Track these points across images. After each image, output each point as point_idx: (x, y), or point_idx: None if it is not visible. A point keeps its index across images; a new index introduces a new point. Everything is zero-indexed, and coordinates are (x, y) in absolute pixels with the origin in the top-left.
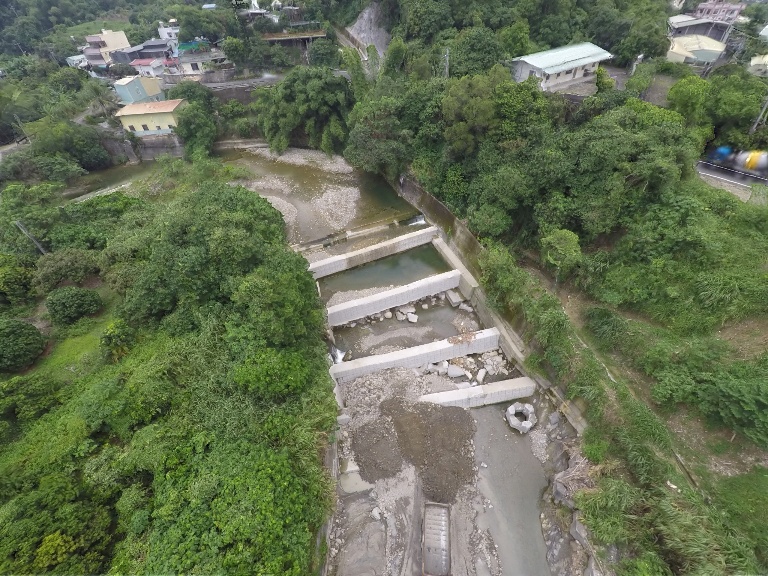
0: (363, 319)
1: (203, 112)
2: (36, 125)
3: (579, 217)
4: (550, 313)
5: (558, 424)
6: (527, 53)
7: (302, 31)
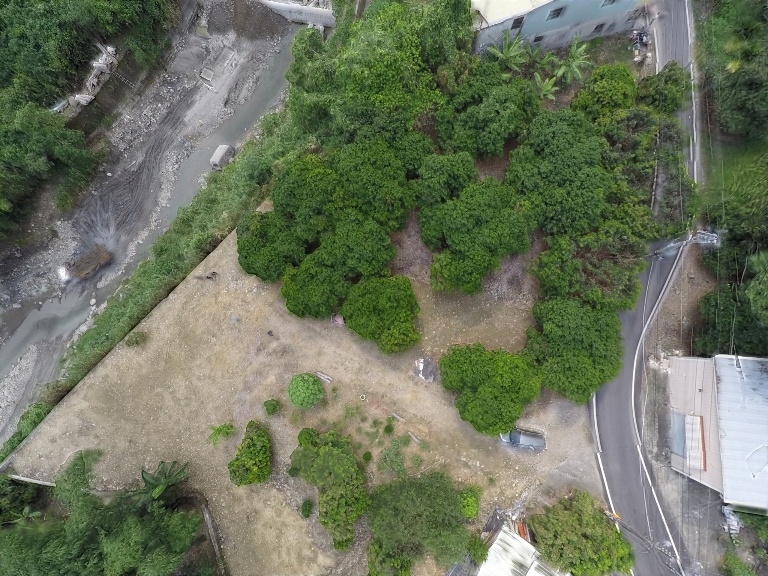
0: None
1: None
2: None
3: None
4: None
5: None
6: None
7: None
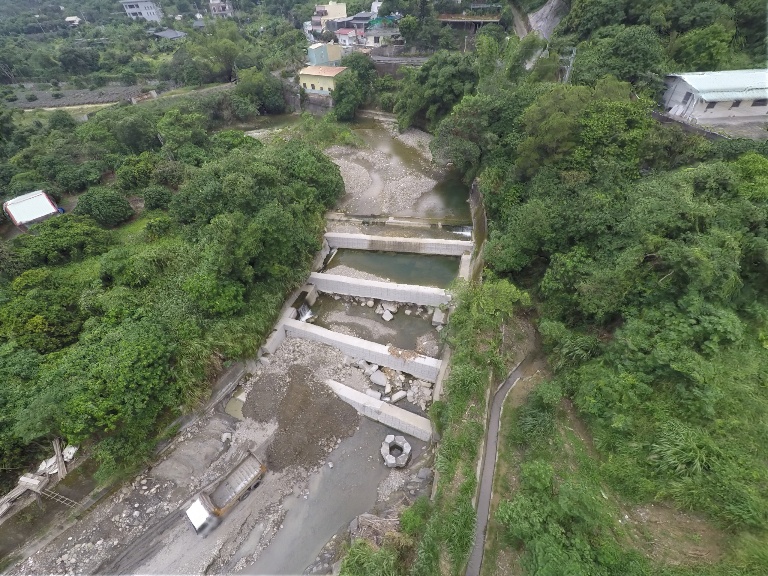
0: (348, 297)
1: (357, 81)
2: (245, 71)
3: None
4: (464, 367)
5: (423, 481)
6: (720, 68)
7: (480, 14)
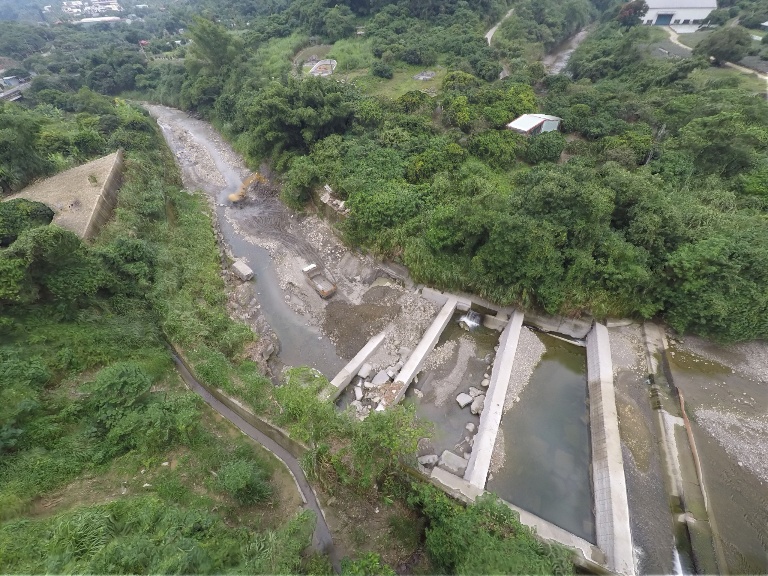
0: None
1: None
2: None
3: None
4: None
5: None
6: None
7: None
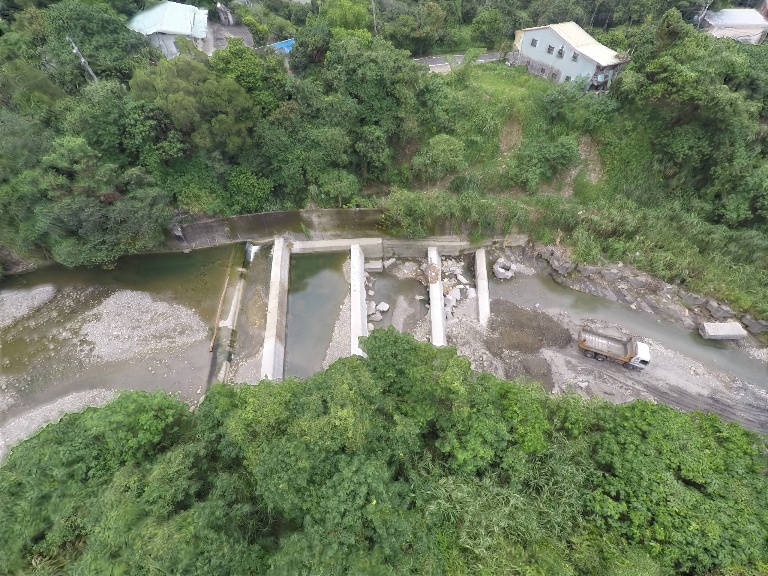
0: None
1: None
2: None
3: (396, 133)
4: (466, 197)
5: (511, 253)
6: None
7: None
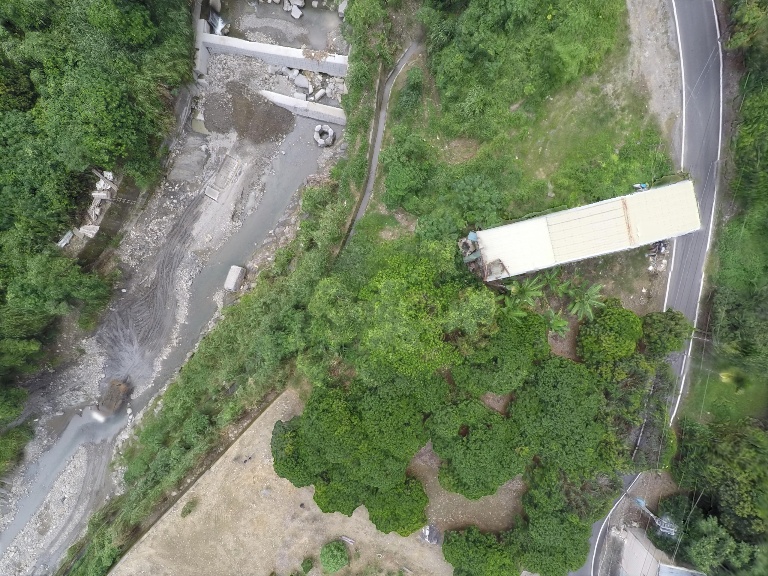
0: None
1: None
2: None
3: None
4: (356, 64)
5: (344, 151)
6: None
7: None
